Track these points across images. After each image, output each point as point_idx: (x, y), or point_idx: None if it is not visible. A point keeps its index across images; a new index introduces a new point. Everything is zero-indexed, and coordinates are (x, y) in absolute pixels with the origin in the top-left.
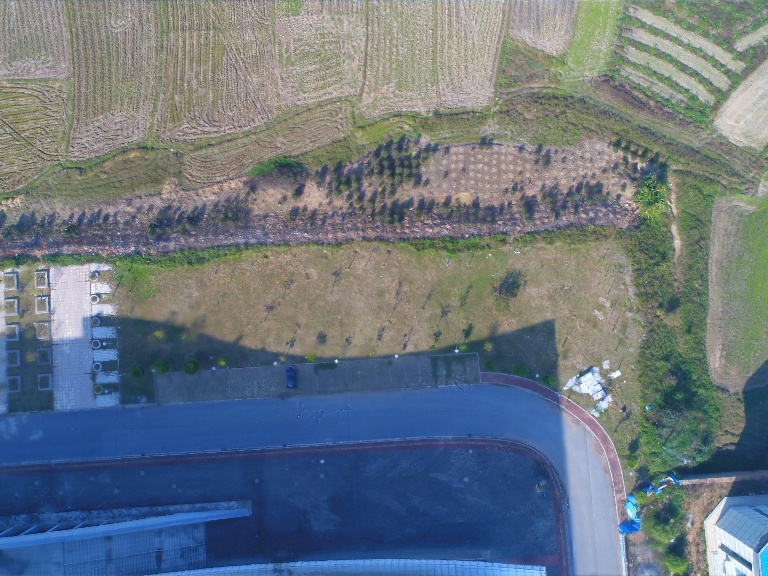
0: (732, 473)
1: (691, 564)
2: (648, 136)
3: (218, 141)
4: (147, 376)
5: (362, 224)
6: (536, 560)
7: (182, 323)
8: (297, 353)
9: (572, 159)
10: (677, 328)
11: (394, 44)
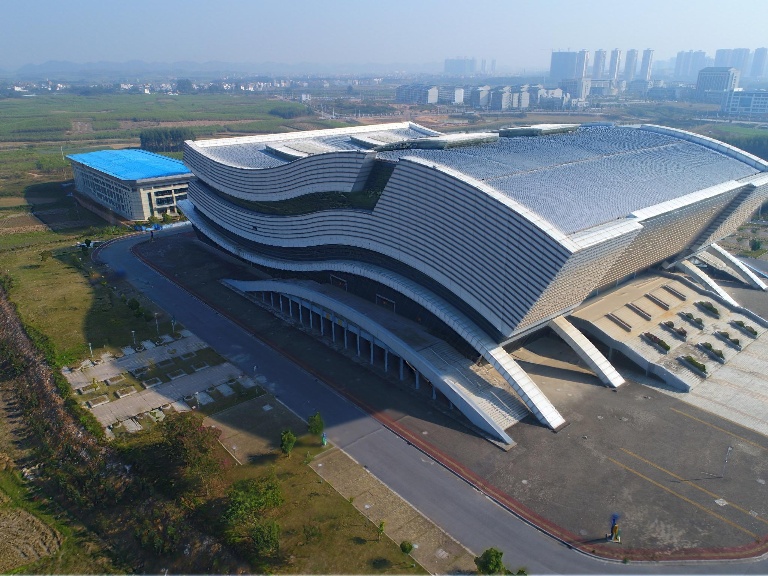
0: (120, 226)
1: None
2: None
3: None
4: (155, 327)
5: None
6: None
7: None
8: None
9: None
10: None
11: None
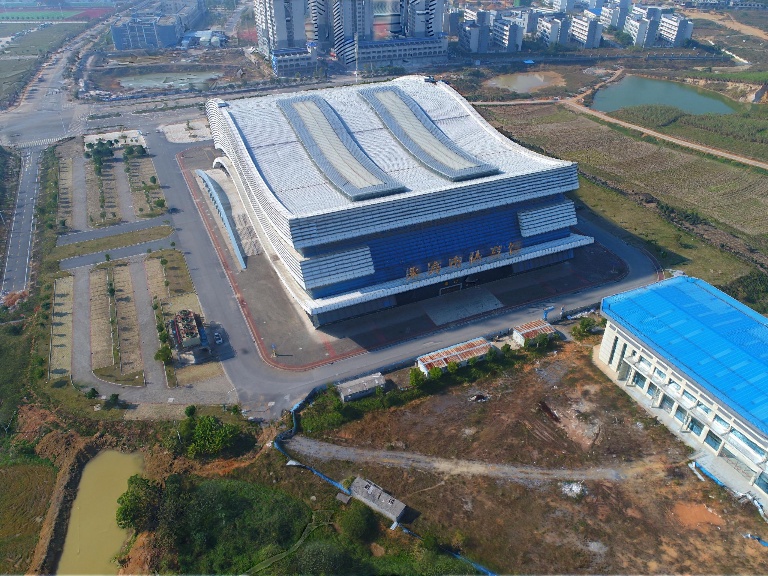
0: None
1: None
2: None
3: None
4: None
5: None
6: None
7: None
8: None
9: None
10: None
11: None
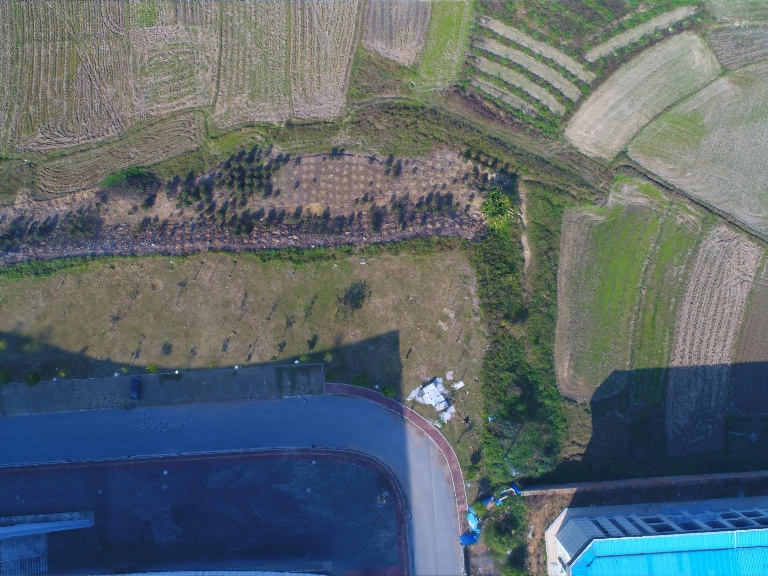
0: (576, 484)
1: (531, 575)
2: (498, 147)
3: (71, 151)
4: None
5: (210, 235)
6: (377, 571)
7: (28, 334)
8: (142, 364)
9: (423, 169)
10: (525, 339)
11: (247, 55)
